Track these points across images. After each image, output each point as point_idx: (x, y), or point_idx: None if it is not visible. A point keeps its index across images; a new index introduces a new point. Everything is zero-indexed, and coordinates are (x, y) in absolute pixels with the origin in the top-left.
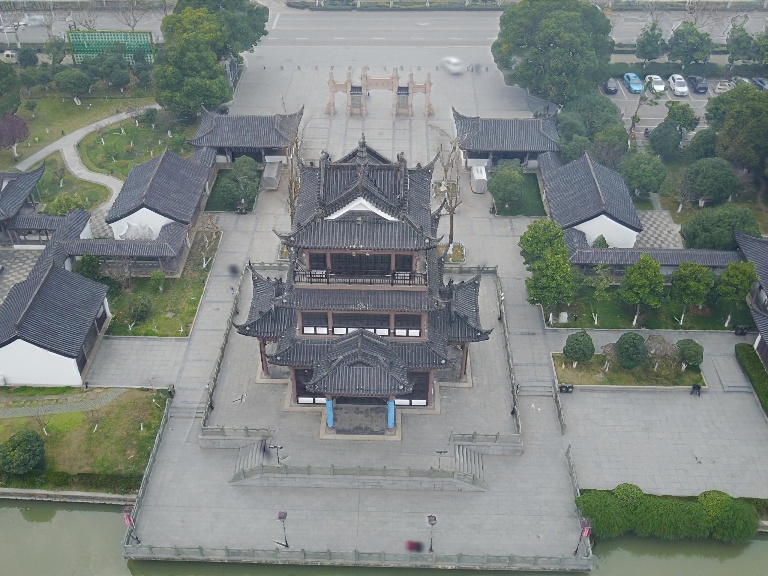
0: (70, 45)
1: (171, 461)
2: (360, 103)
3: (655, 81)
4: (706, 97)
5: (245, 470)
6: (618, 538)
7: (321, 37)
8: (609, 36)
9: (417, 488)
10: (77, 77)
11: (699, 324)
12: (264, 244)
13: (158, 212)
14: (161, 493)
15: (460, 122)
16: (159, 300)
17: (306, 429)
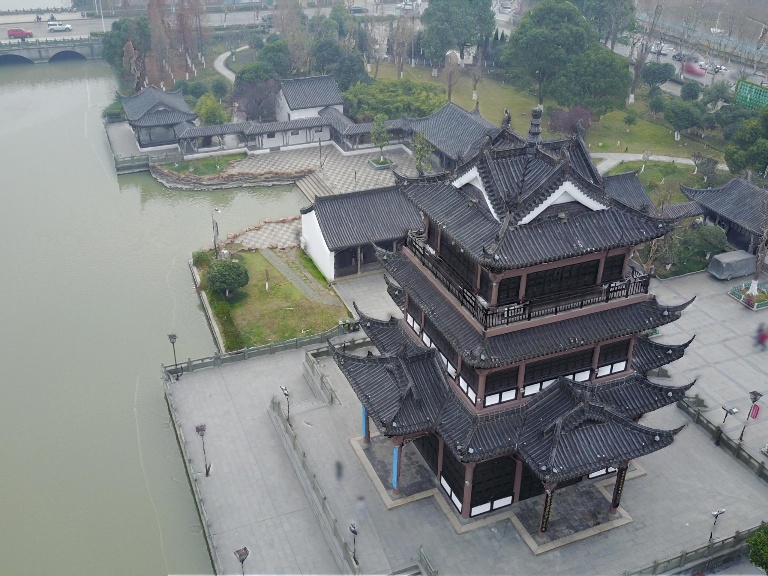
0: (735, 94)
1: (277, 363)
2: None
3: None
4: None
5: (274, 400)
6: None
7: None
8: None
9: None
10: (684, 109)
11: None
12: None
13: None
14: (237, 371)
15: None
16: None
17: (358, 425)
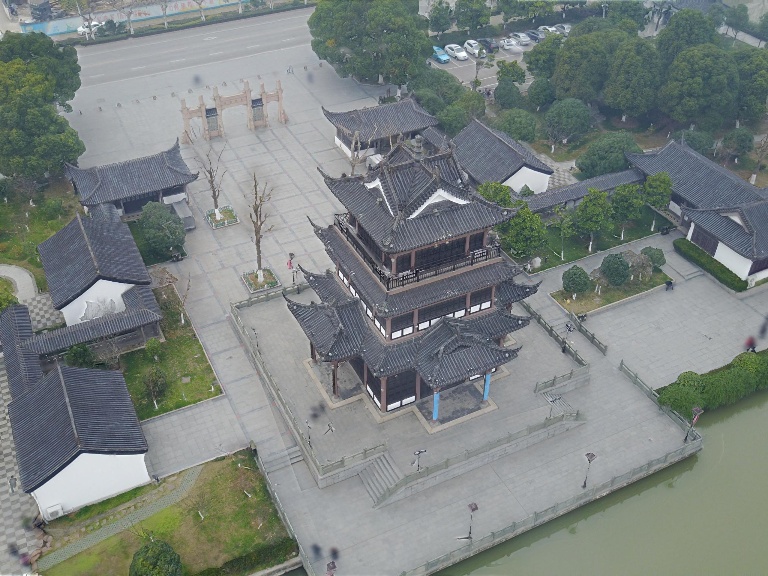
0: None
1: (302, 513)
2: (217, 125)
3: (456, 49)
4: (501, 55)
5: (390, 488)
6: (699, 417)
7: (116, 70)
8: (422, 15)
9: (534, 443)
10: None
11: (634, 235)
12: (225, 283)
13: (116, 280)
14: (318, 545)
15: (335, 119)
16: (162, 370)
17: (411, 431)
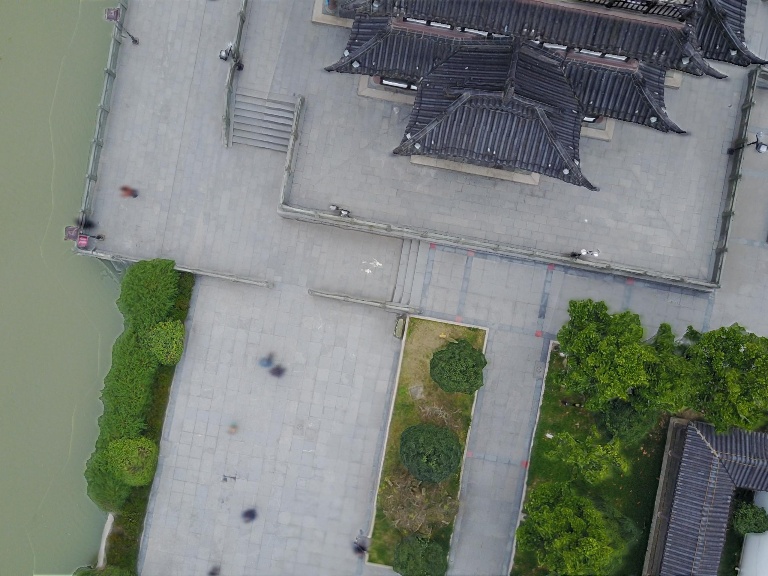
0: None
1: None
2: None
3: None
4: None
5: None
6: None
7: None
8: None
9: None
10: None
11: None
12: None
13: None
14: None
15: None
16: None
17: None
